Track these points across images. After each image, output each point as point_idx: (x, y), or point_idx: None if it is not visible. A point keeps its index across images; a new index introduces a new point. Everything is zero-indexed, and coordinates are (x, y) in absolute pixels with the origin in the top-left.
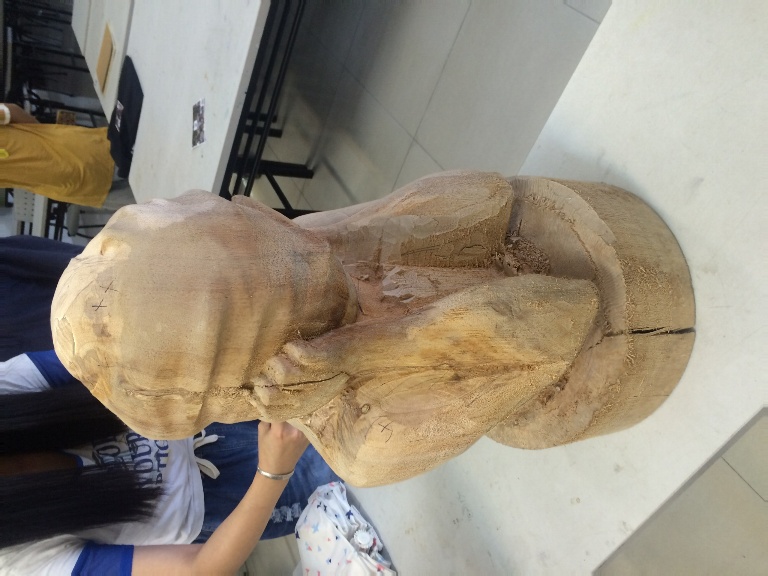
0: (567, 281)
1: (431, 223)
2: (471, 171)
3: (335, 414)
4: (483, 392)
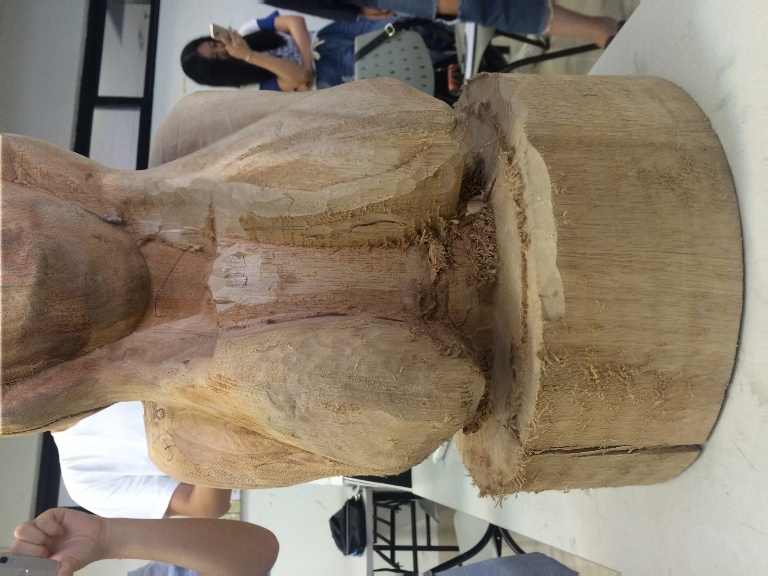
0: (426, 370)
1: (281, 200)
2: (386, 106)
3: None
4: (275, 461)
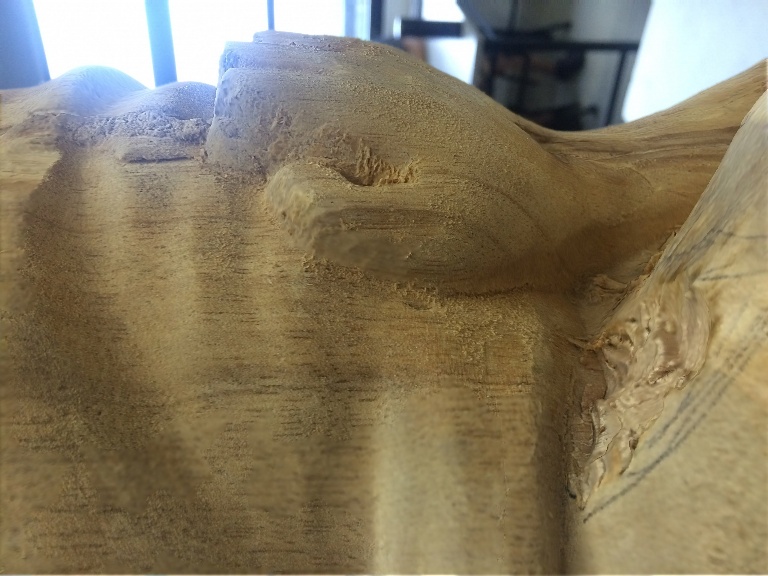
0: None
1: None
2: None
3: (658, 305)
4: None
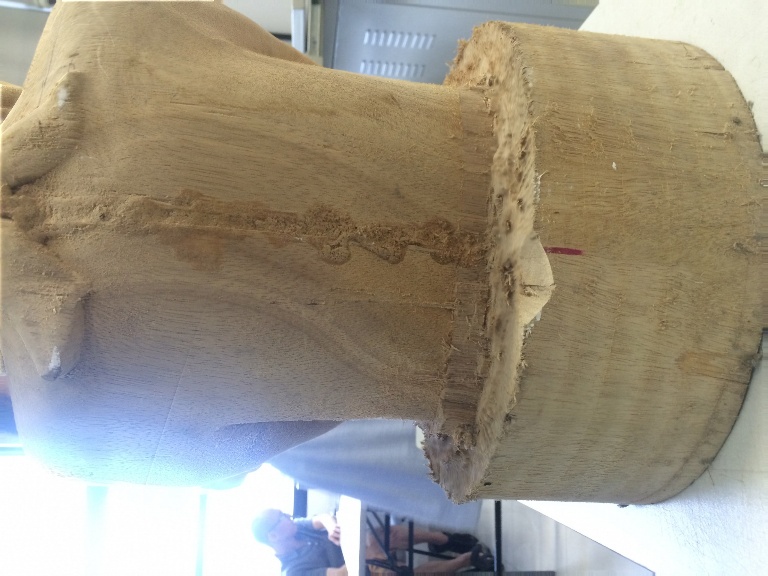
0: None
1: None
2: None
3: None
4: None
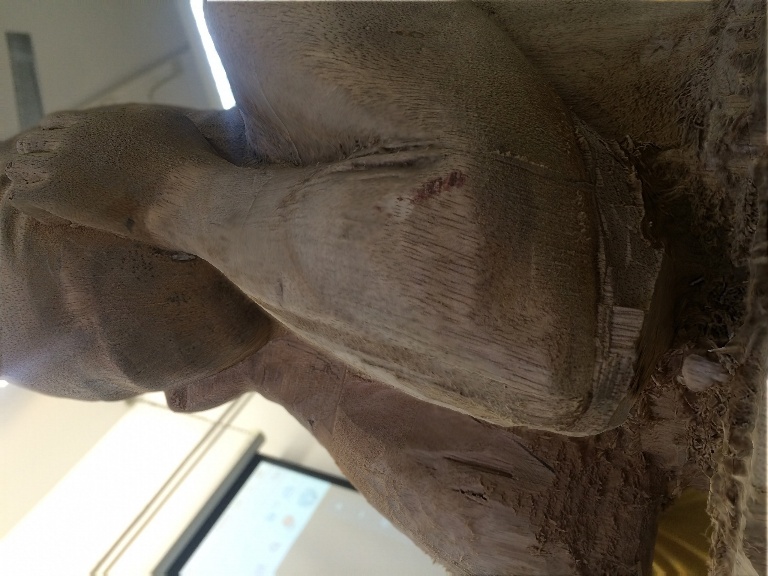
0: None
1: None
2: (428, 348)
3: None
4: None
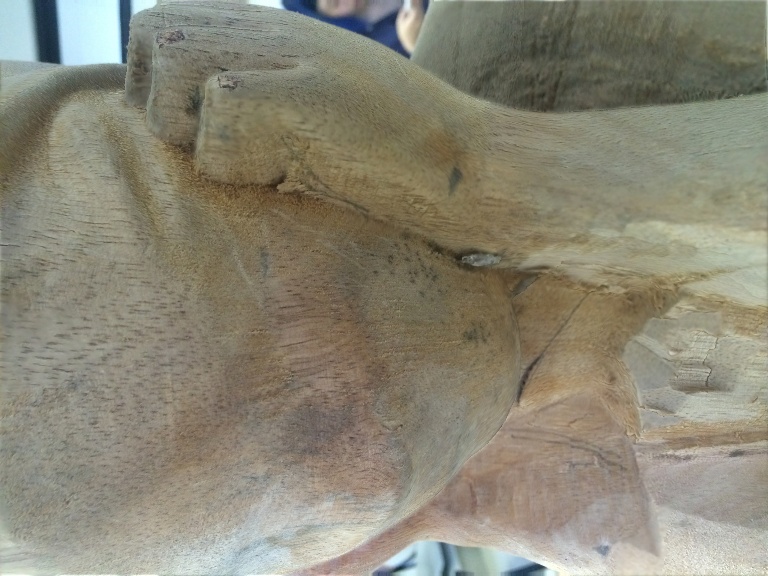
0: None
1: None
2: None
3: None
4: None
